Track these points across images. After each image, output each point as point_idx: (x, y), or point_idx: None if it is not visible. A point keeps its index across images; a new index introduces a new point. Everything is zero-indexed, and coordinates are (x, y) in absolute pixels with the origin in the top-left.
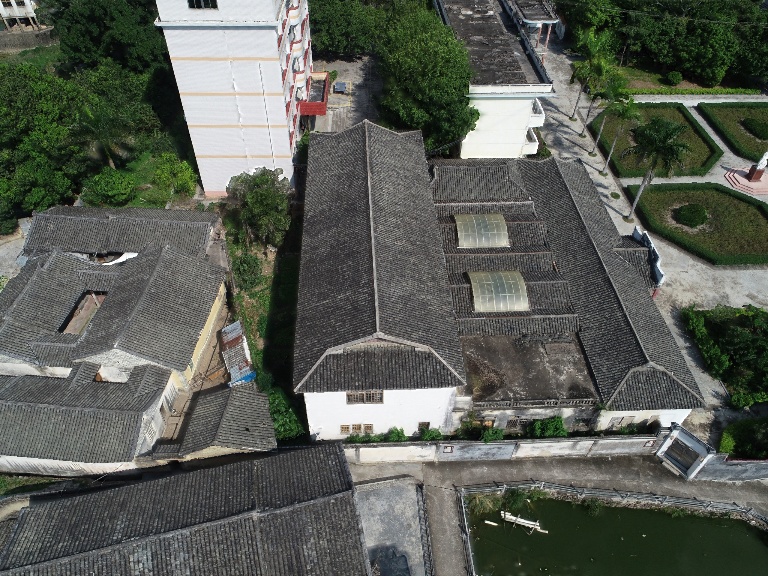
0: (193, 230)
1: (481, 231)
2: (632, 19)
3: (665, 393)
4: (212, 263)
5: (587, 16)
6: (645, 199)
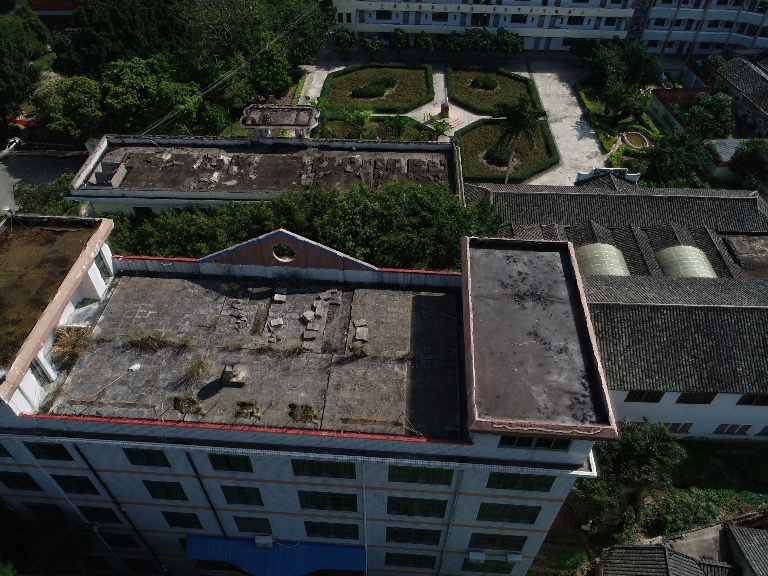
0: (679, 575)
1: (617, 263)
2: (227, 81)
3: (762, 203)
4: (736, 539)
5: (181, 108)
6: (476, 174)
